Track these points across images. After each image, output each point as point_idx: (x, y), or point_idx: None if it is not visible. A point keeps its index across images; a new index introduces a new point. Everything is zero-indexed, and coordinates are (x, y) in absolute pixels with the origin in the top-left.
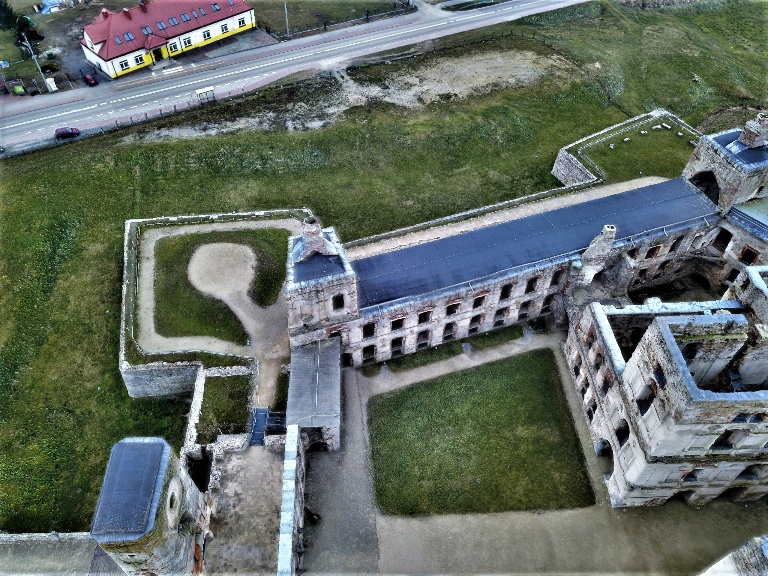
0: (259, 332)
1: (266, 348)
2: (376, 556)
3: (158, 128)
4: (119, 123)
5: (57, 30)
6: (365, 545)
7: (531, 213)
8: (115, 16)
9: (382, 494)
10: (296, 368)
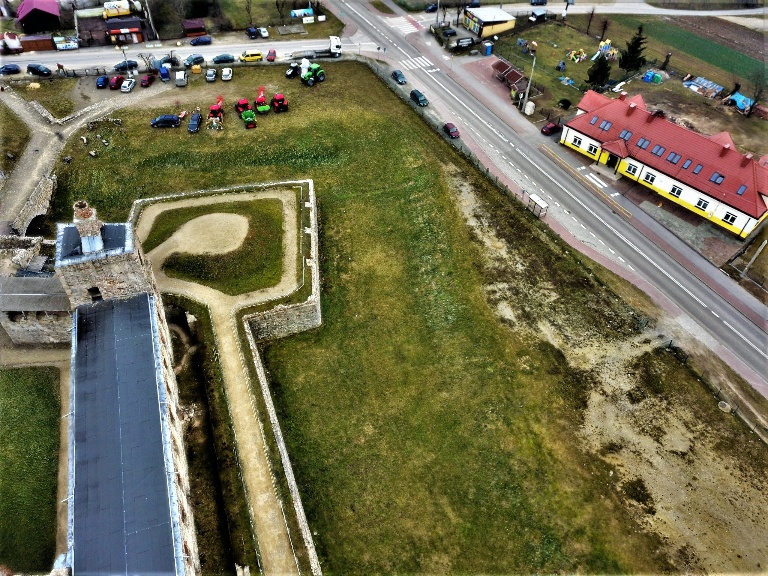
0: None
1: None
2: None
3: (473, 184)
4: (477, 158)
5: (649, 96)
6: None
7: (273, 571)
8: (620, 103)
9: None
10: (56, 280)
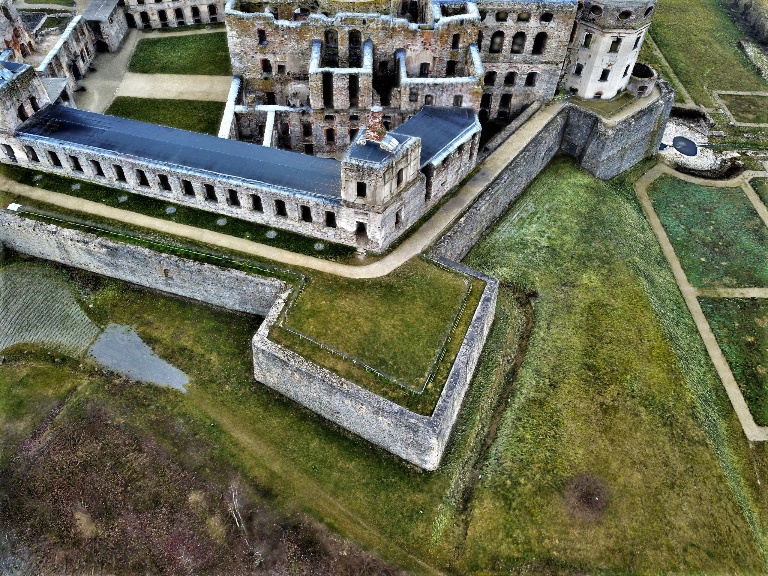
0: (82, 2)
1: (84, 7)
2: (120, 82)
3: None
4: None
5: None
6: (116, 79)
7: None
8: None
9: (132, 66)
10: (92, 4)
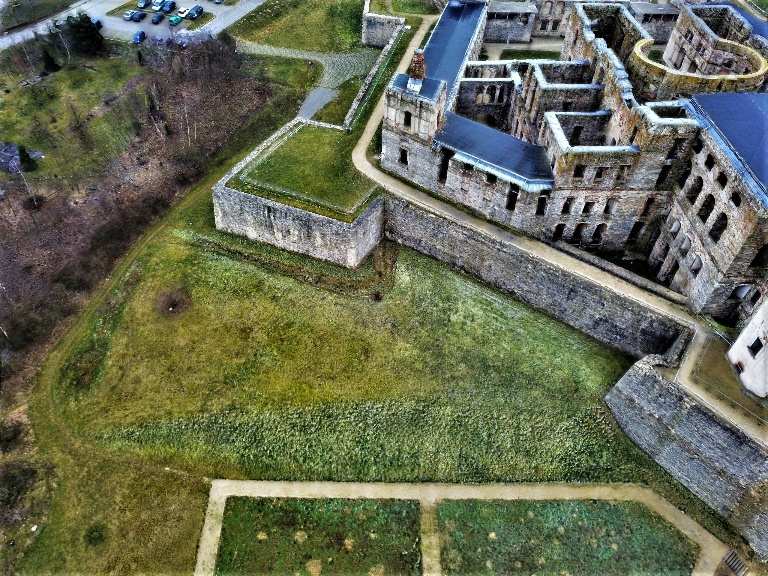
0: None
1: None
2: None
3: None
4: None
5: None
6: None
7: None
8: None
9: None
10: (660, 4)
